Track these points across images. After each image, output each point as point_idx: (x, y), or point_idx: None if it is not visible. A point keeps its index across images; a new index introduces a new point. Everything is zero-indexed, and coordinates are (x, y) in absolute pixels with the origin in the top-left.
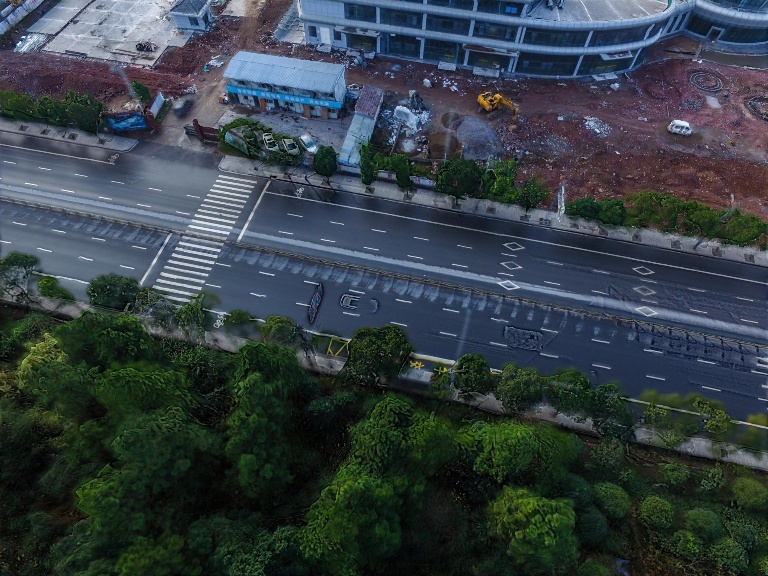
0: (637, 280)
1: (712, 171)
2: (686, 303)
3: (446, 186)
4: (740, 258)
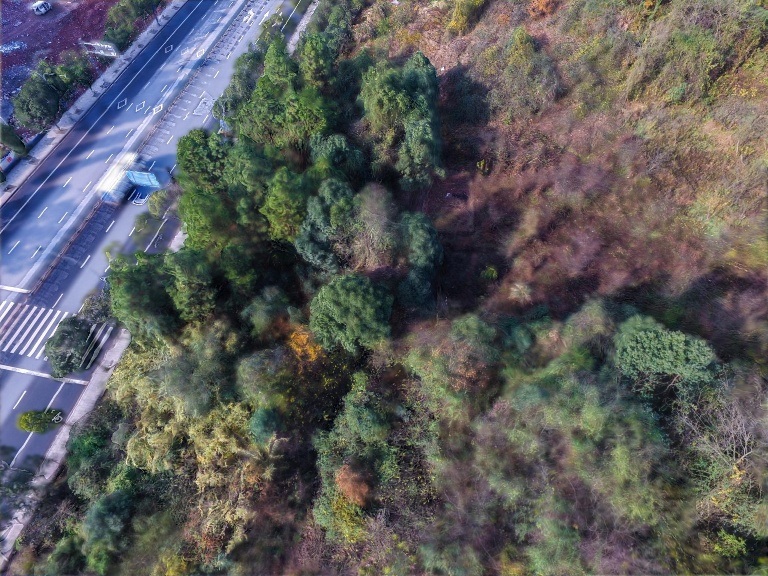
0: (175, 52)
1: (95, 5)
2: (200, 37)
3: (46, 107)
4: (174, 11)
